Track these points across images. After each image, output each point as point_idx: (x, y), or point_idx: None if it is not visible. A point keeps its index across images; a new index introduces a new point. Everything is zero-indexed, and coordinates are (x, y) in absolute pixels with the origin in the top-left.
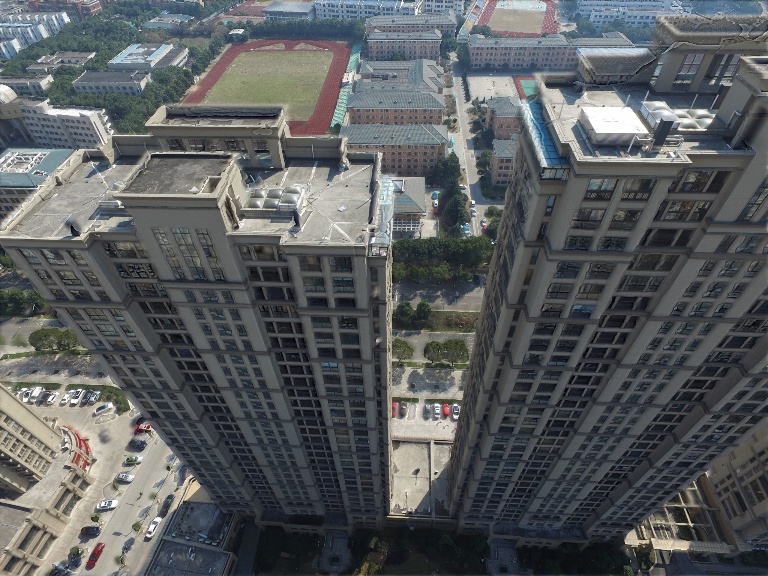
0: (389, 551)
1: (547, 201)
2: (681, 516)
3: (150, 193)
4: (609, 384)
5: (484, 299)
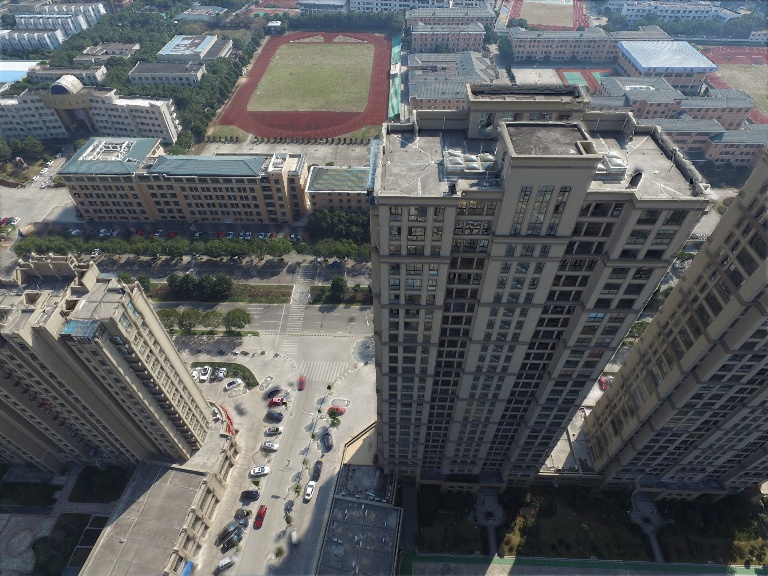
0: (539, 506)
1: None
2: None
3: (543, 154)
4: None
5: (706, 260)
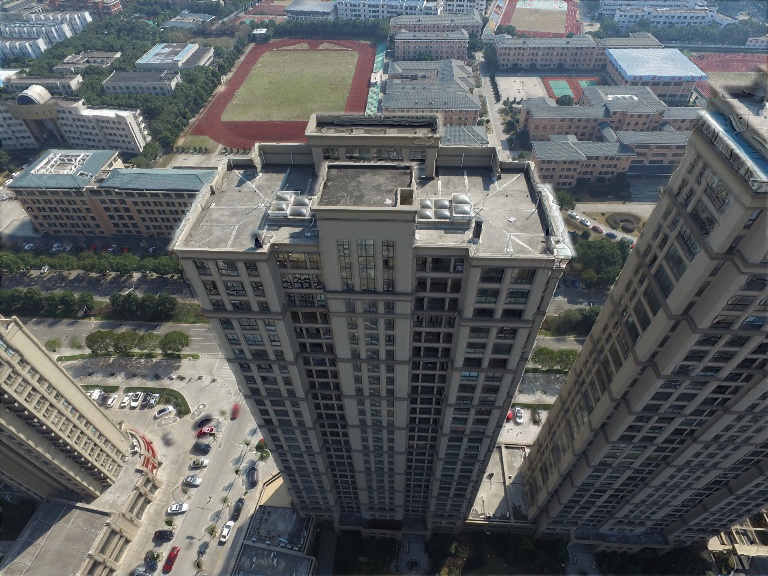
0: (467, 556)
1: (751, 214)
2: (757, 521)
3: (348, 205)
4: (749, 394)
5: (610, 307)
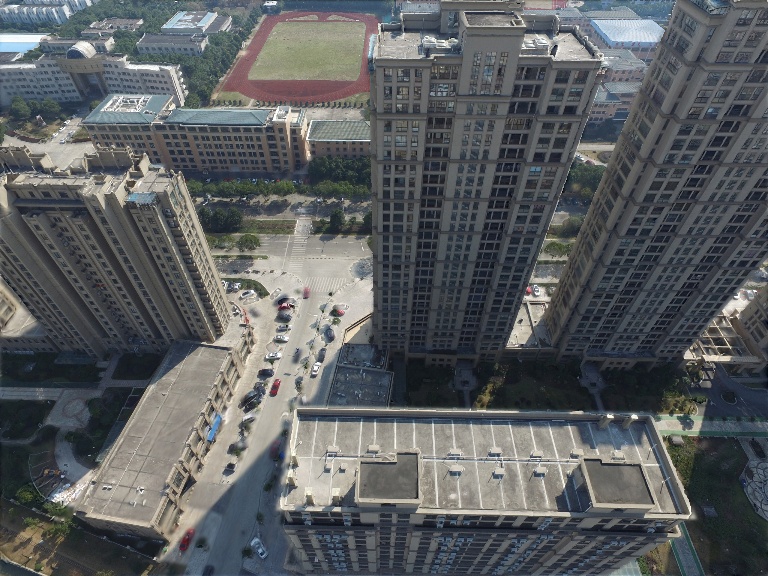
0: (506, 375)
1: (710, 31)
2: (719, 350)
3: (487, 25)
4: (711, 183)
5: (621, 139)
